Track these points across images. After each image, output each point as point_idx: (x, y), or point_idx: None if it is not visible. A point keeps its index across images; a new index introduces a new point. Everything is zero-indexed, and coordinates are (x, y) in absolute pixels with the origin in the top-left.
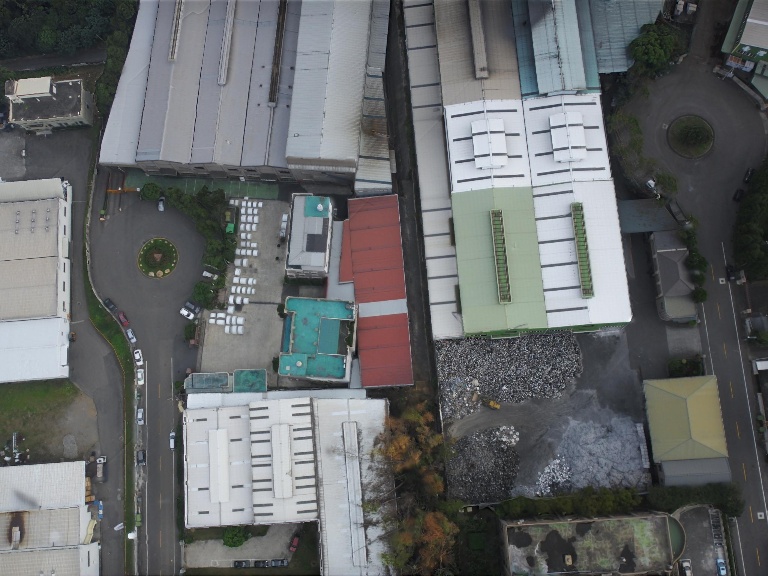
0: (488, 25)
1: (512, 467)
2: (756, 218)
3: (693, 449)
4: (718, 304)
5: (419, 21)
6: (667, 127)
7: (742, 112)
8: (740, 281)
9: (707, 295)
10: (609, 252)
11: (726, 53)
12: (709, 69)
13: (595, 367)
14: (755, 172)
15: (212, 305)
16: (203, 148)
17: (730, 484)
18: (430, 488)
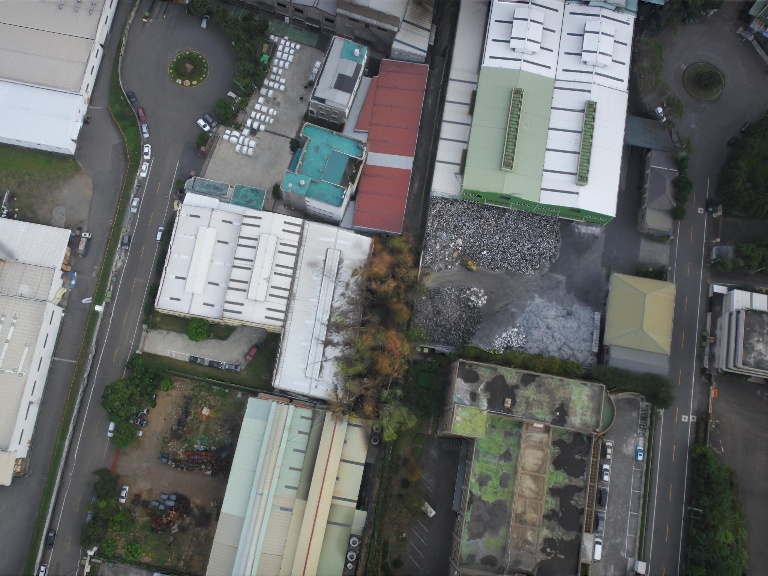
0: None
1: (474, 324)
2: (745, 157)
3: (641, 340)
4: (692, 228)
5: None
6: (685, 68)
7: (753, 73)
8: (716, 214)
9: (685, 214)
10: (609, 152)
11: (752, 16)
12: (734, 29)
13: (570, 257)
14: (752, 125)
15: (230, 122)
16: None
17: (666, 377)
18: (397, 315)
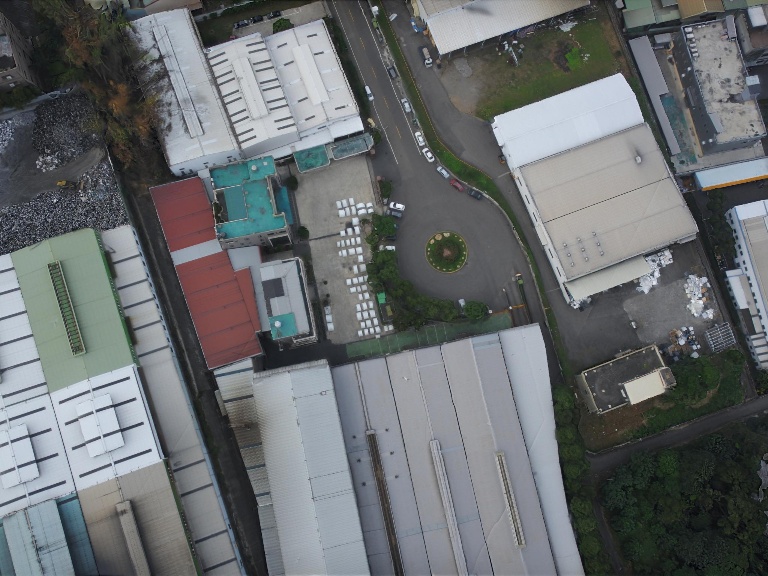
0: (130, 574)
1: None
2: None
3: None
4: None
5: (222, 570)
6: None
7: None
8: None
9: None
10: None
11: None
12: None
13: None
14: None
15: None
16: (430, 365)
17: None
18: None
